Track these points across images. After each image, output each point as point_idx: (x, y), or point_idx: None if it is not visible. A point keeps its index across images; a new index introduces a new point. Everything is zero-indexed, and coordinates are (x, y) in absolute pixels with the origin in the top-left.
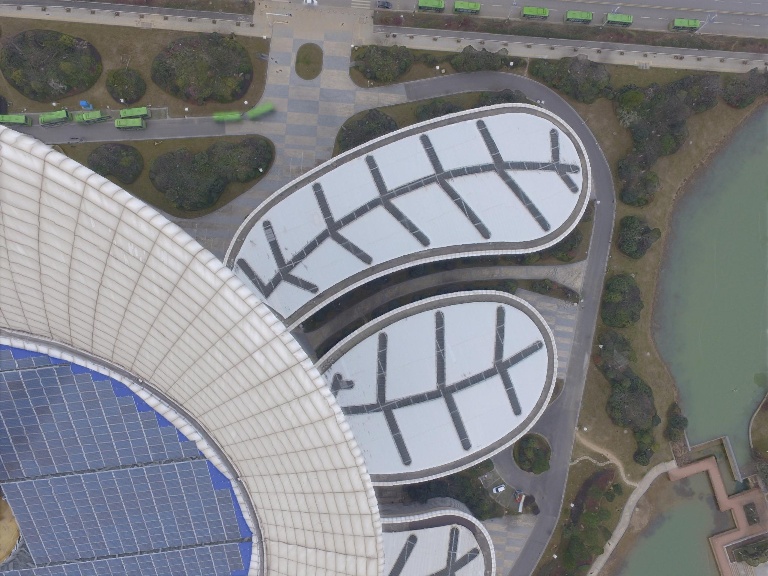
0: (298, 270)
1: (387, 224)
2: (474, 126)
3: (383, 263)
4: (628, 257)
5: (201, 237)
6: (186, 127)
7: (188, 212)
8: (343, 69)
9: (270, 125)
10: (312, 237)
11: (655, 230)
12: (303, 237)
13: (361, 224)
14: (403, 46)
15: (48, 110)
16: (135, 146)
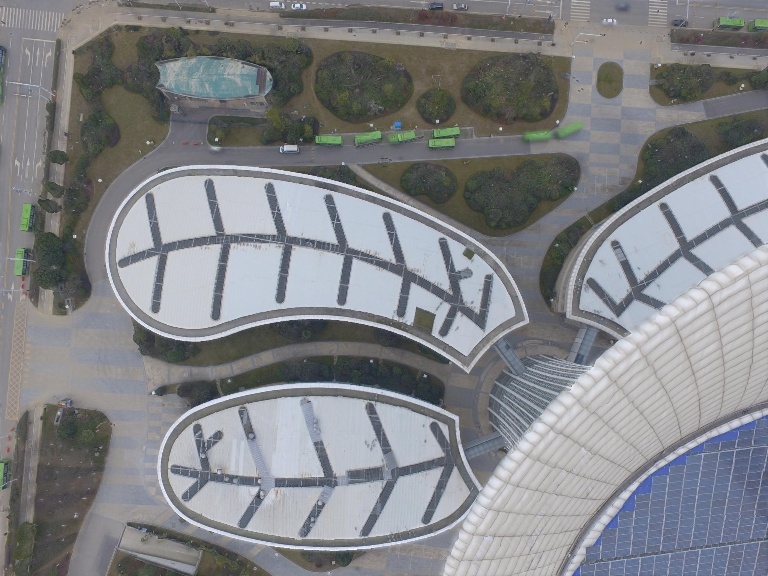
0: (650, 289)
1: (738, 243)
2: None
3: None
4: None
5: (511, 255)
6: (492, 146)
7: (499, 230)
8: (643, 87)
9: (574, 143)
10: (665, 257)
11: None
12: (655, 257)
13: (713, 243)
14: (708, 64)
15: (358, 130)
16: (445, 165)
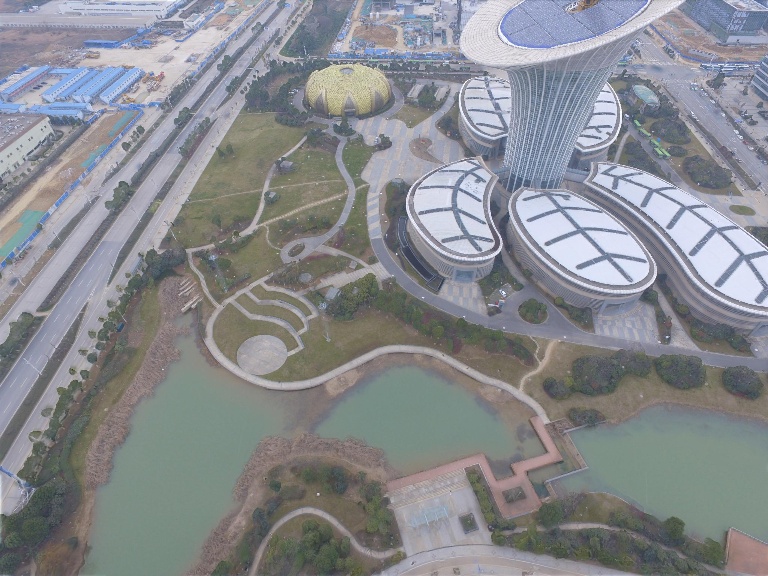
0: None
1: (671, 210)
2: (763, 249)
3: (644, 214)
4: (721, 380)
5: None
6: (668, 170)
7: None
8: (749, 223)
9: None
10: (645, 185)
11: (760, 382)
12: (643, 182)
13: (664, 200)
14: None
15: None
16: None
